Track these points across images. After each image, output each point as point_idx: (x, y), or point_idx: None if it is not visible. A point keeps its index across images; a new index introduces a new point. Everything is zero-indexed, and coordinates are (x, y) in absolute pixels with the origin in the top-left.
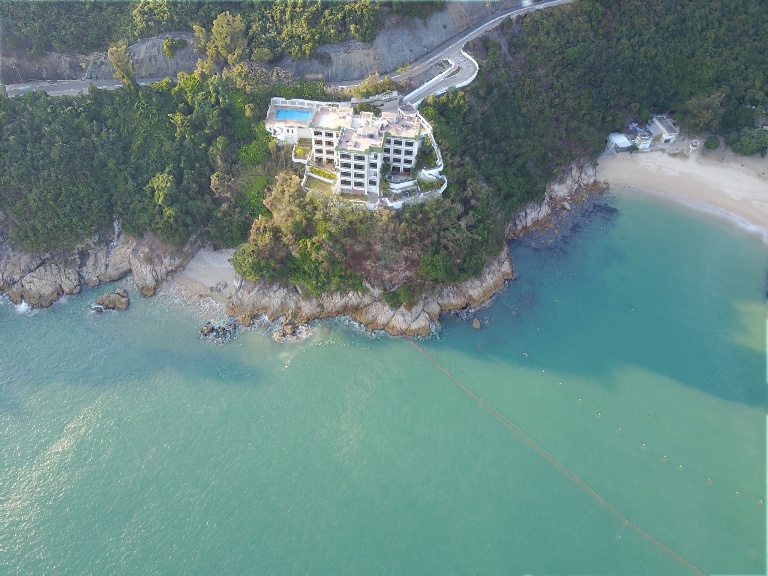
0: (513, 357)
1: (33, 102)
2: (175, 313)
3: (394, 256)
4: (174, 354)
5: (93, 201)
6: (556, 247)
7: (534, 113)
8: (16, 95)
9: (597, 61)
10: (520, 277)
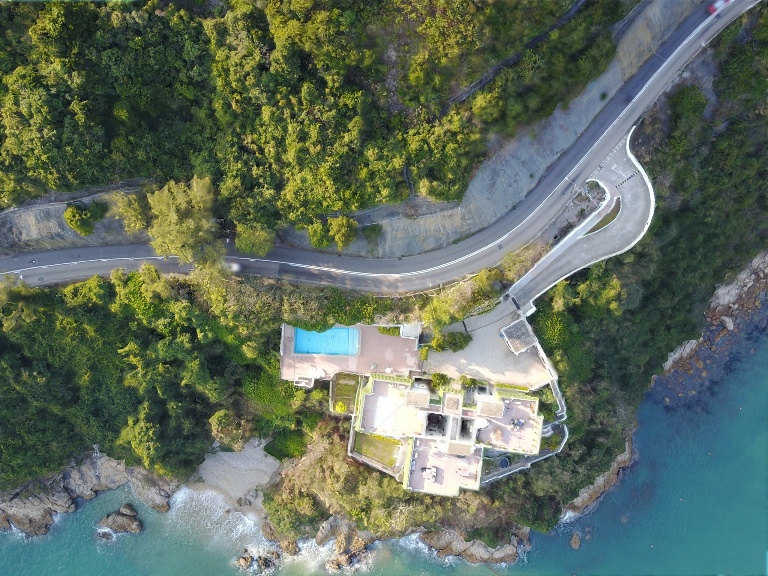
0: None
1: None
2: (201, 535)
3: None
4: None
5: (50, 443)
6: (698, 403)
7: (726, 209)
8: None
9: None
10: (640, 459)
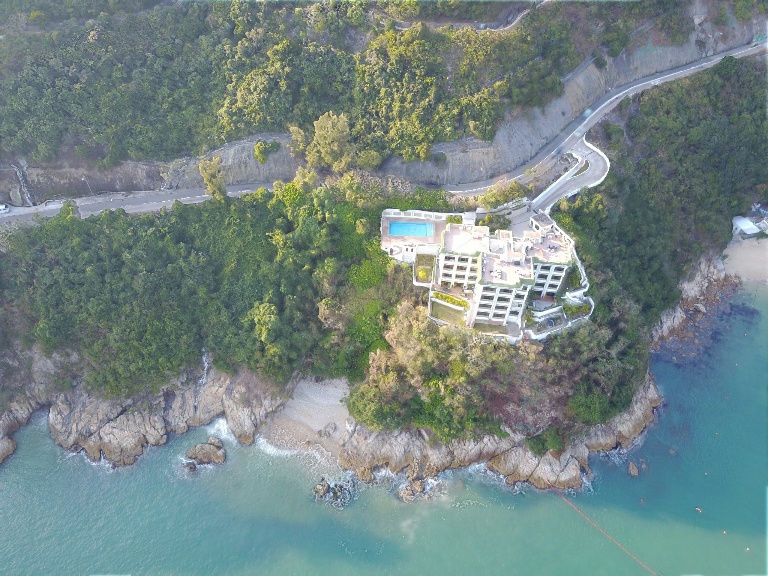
0: (685, 514)
1: (110, 223)
2: (281, 466)
3: (541, 397)
4: (287, 523)
5: (181, 336)
6: (700, 362)
7: (662, 205)
8: (90, 216)
9: (721, 140)
10: (668, 403)
